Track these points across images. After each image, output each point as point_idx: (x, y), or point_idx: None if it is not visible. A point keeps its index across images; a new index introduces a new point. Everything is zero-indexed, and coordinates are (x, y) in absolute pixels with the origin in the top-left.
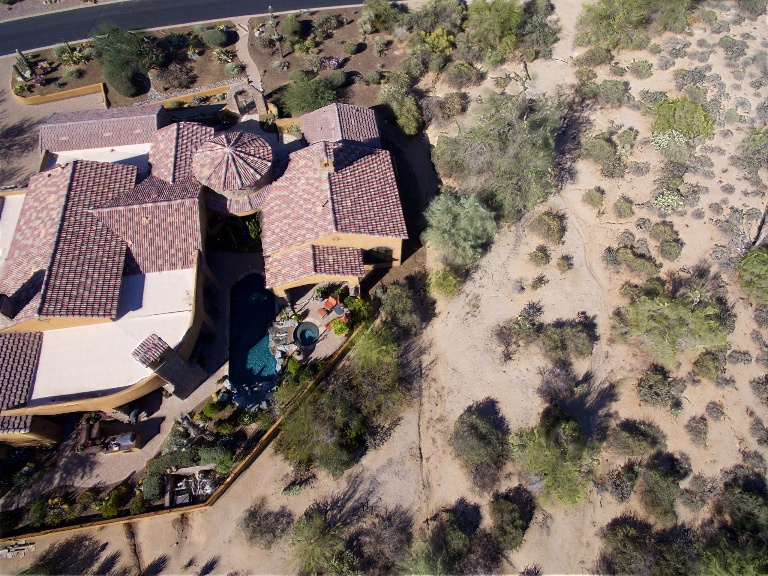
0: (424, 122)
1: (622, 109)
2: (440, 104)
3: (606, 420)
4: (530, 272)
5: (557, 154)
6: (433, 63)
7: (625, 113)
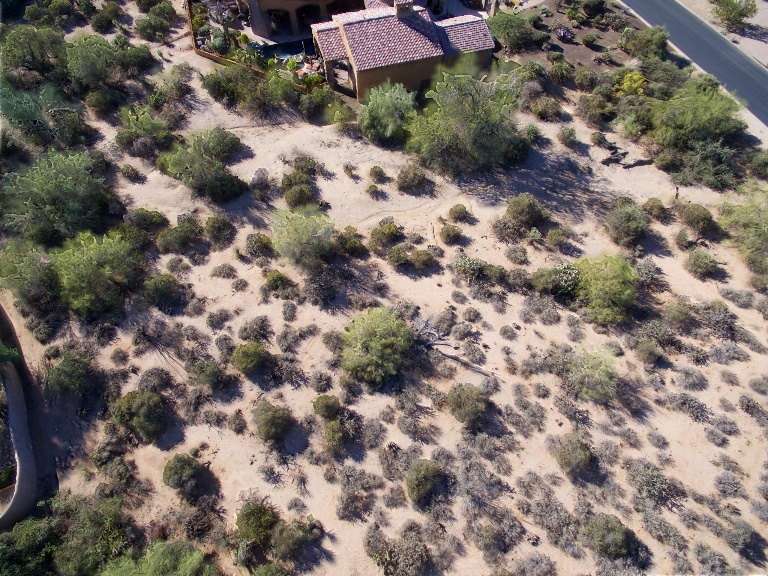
0: (514, 94)
1: (614, 245)
2: (534, 93)
3: (239, 220)
4: (365, 172)
5: (515, 190)
6: (597, 87)
7: (607, 247)
